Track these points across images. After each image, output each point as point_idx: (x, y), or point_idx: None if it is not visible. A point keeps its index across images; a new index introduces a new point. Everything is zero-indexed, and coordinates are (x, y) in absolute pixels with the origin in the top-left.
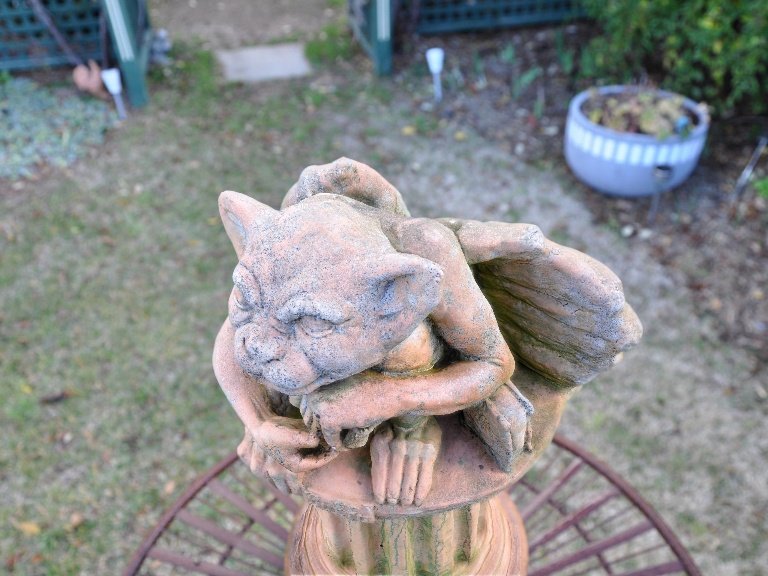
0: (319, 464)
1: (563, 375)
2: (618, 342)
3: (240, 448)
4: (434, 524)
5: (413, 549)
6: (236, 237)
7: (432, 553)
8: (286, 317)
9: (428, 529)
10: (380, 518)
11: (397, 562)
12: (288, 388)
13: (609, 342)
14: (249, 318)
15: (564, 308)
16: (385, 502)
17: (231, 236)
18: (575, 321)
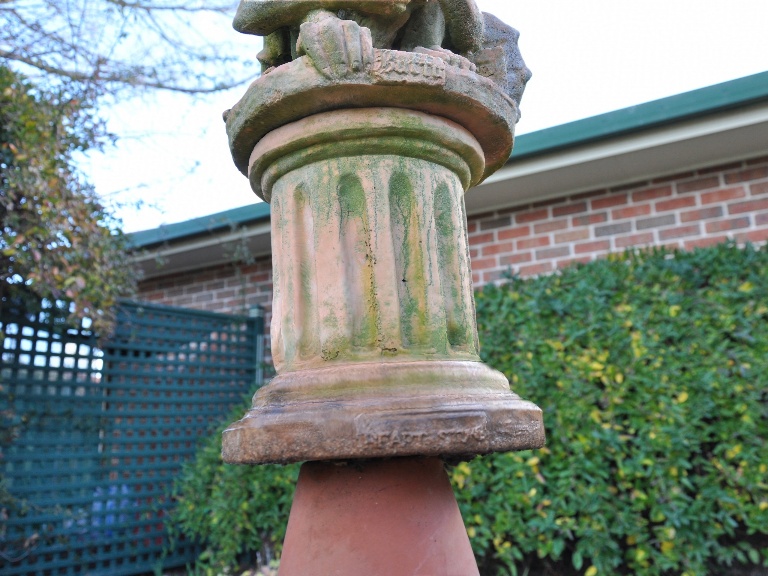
0: None
1: None
2: (523, 68)
3: None
4: (455, 223)
5: None
6: None
7: (456, 282)
8: None
9: (448, 239)
10: (447, 85)
11: (431, 280)
12: None
13: (517, 72)
14: None
15: None
16: (449, 64)
17: None
18: None
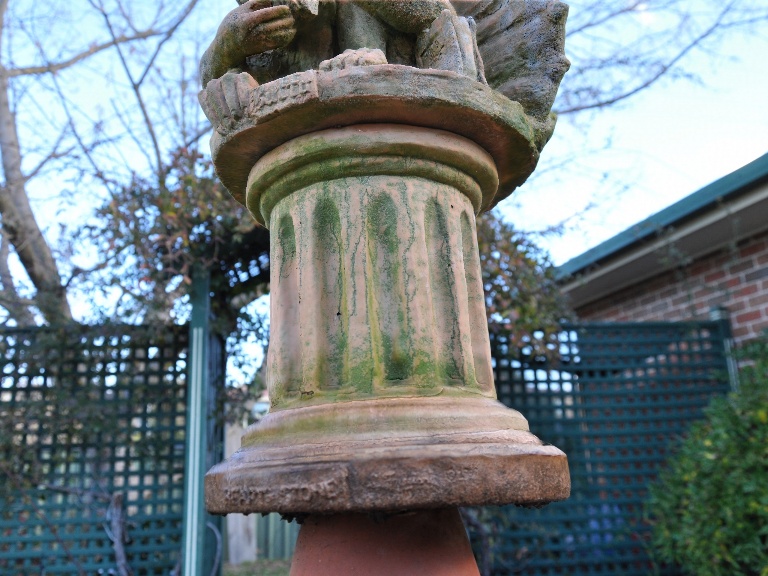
0: (269, 8)
1: (521, 91)
2: (548, 6)
3: None
4: (400, 236)
5: (378, 302)
6: None
7: (402, 305)
8: None
9: (394, 255)
10: (324, 96)
11: (355, 309)
12: None
13: (542, 13)
14: None
15: (499, 9)
16: None
17: None
18: (510, 13)
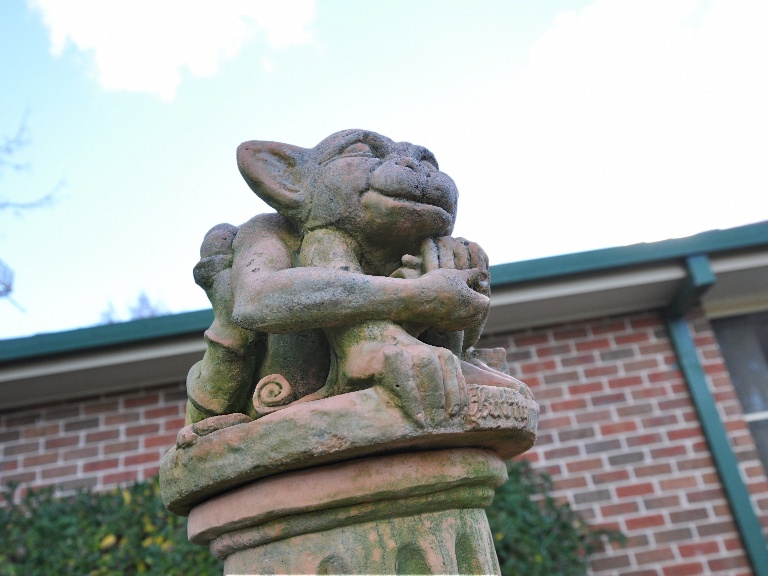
0: None
1: None
2: None
3: (391, 348)
4: None
5: None
6: (267, 176)
7: None
8: (415, 155)
9: None
10: None
11: None
12: (450, 198)
13: None
14: None
15: None
16: None
17: (261, 175)
18: None
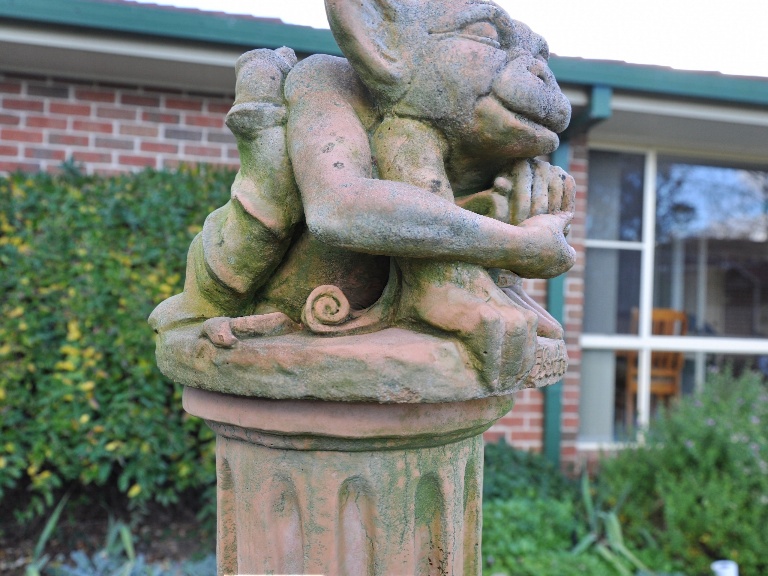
0: None
1: None
2: None
3: (489, 312)
4: None
5: None
6: (361, 28)
7: None
8: (537, 49)
9: None
10: None
11: None
12: None
13: None
14: (506, 57)
15: None
16: None
17: (355, 26)
18: None
